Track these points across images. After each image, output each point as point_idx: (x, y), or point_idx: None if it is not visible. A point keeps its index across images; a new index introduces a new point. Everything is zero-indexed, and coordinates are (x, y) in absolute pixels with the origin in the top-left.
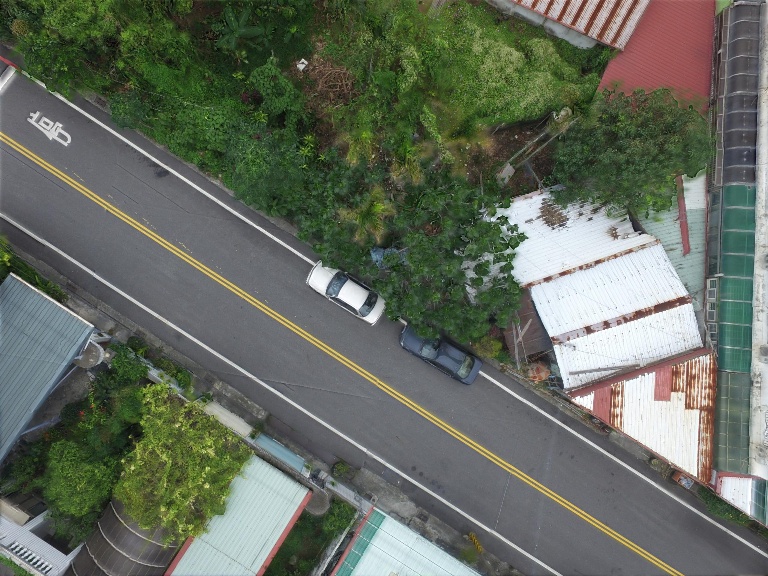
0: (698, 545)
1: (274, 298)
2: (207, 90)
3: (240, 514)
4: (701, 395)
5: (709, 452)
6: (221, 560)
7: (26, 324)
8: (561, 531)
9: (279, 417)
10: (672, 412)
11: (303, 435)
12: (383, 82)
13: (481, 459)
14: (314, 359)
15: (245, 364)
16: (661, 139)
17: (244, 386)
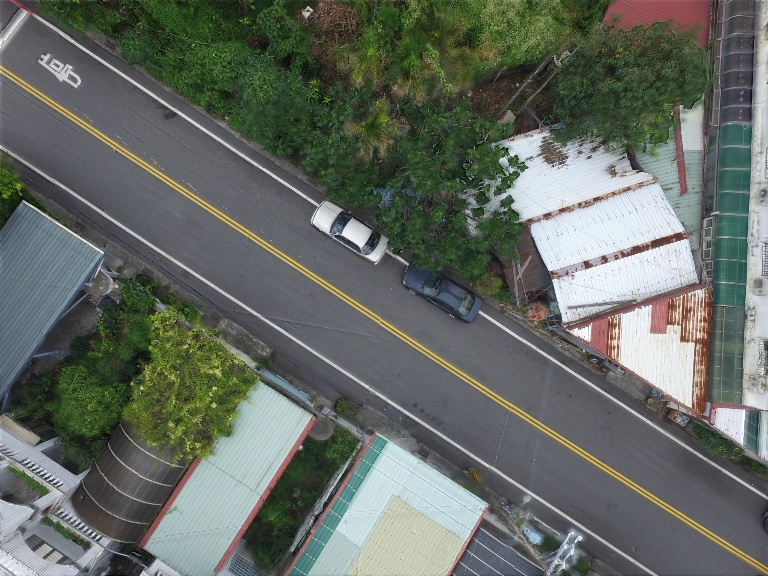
0: (693, 482)
1: (279, 238)
2: (214, 33)
3: (246, 438)
4: (696, 328)
5: (704, 384)
6: (227, 481)
7: (38, 250)
8: (559, 468)
9: (283, 354)
10: (668, 345)
11: (307, 372)
12: (387, 19)
13: (481, 397)
14: (318, 298)
15: (250, 302)
16: (658, 66)
17: (249, 324)
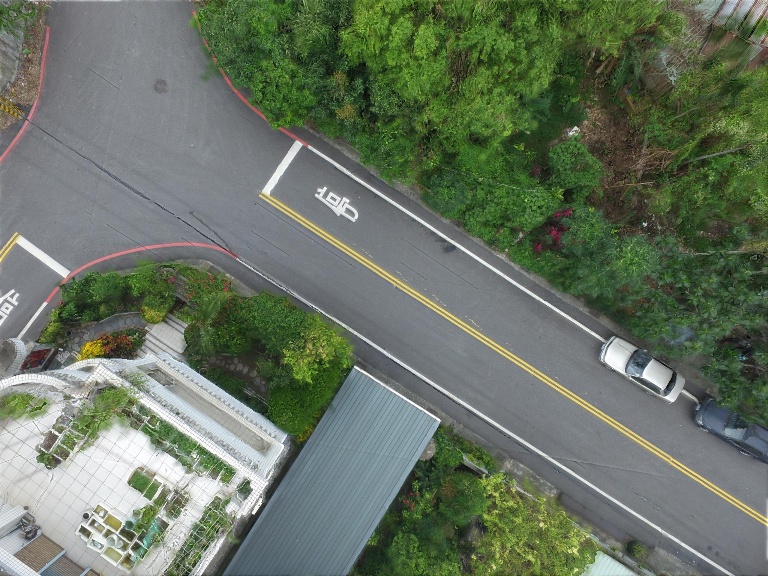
0: None
1: (564, 375)
2: None
3: None
4: None
5: None
6: None
7: (374, 419)
8: None
9: (571, 495)
10: None
11: (595, 513)
12: None
13: None
14: (605, 436)
15: (536, 442)
16: None
17: (536, 464)
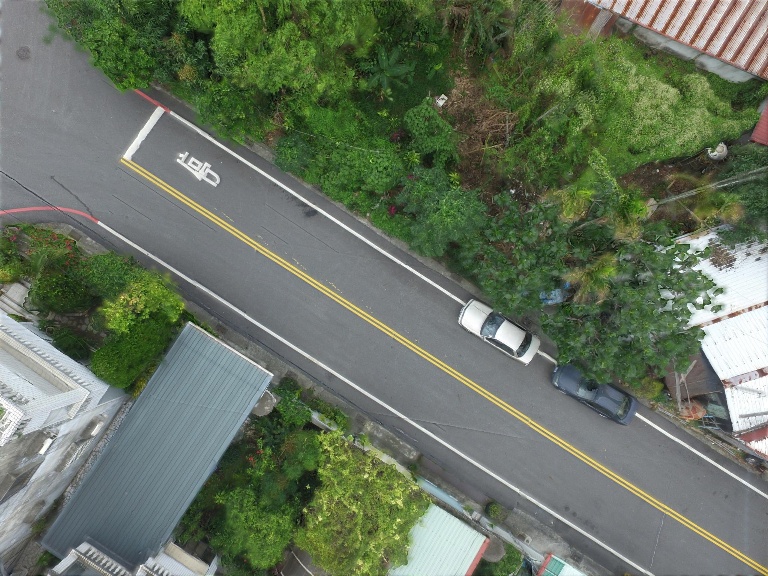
0: None
1: (424, 338)
2: (358, 129)
3: (419, 563)
4: None
5: None
6: None
7: (207, 373)
8: (716, 572)
9: None
10: None
11: (455, 475)
12: (555, 125)
13: (635, 499)
14: (465, 399)
15: (396, 404)
16: None
17: None
